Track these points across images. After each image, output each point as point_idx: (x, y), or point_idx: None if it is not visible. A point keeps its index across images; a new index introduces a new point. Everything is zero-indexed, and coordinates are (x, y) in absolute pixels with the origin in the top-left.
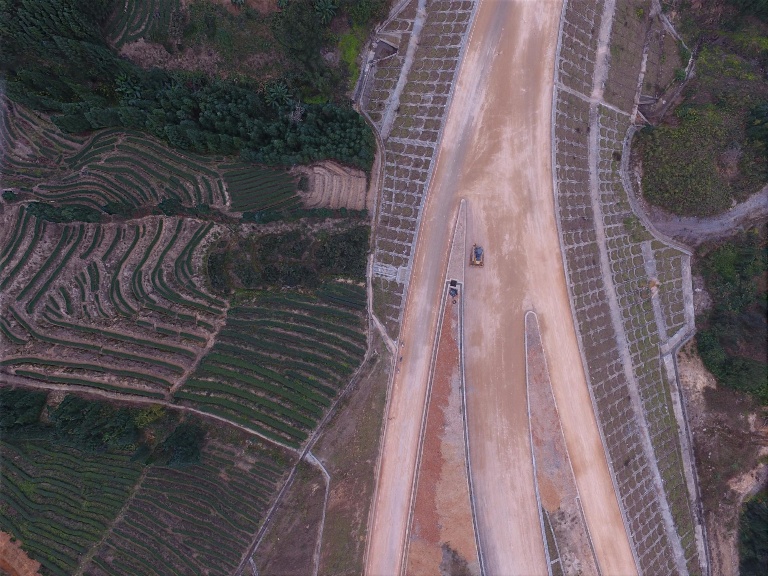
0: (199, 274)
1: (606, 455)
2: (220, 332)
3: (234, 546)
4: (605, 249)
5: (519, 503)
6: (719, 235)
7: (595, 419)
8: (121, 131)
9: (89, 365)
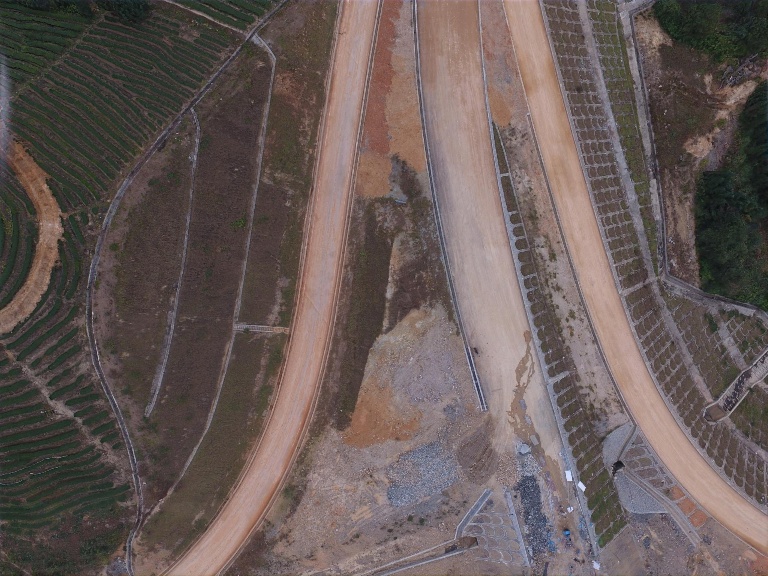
0: None
1: (557, 71)
2: None
3: (175, 96)
4: None
5: (469, 117)
6: None
7: (546, 36)
8: None
9: None
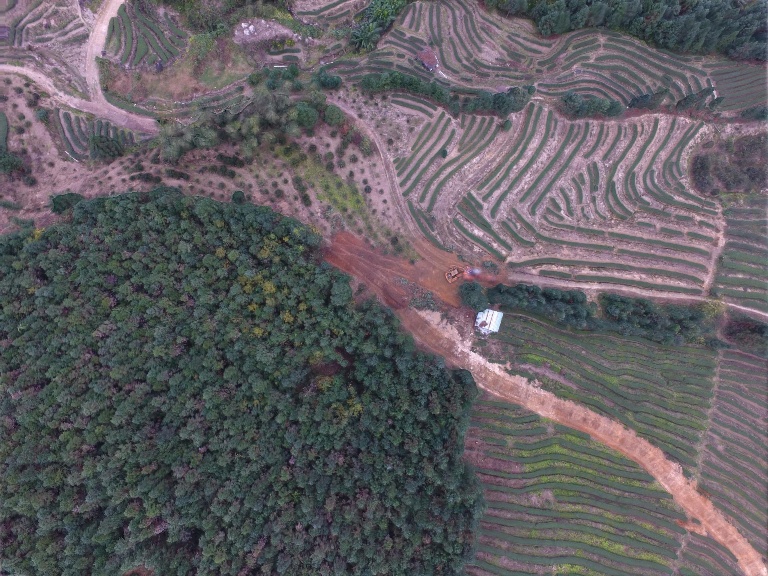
0: (686, 176)
1: None
2: (726, 231)
3: None
4: None
5: None
6: None
7: None
8: (596, 32)
9: (614, 264)
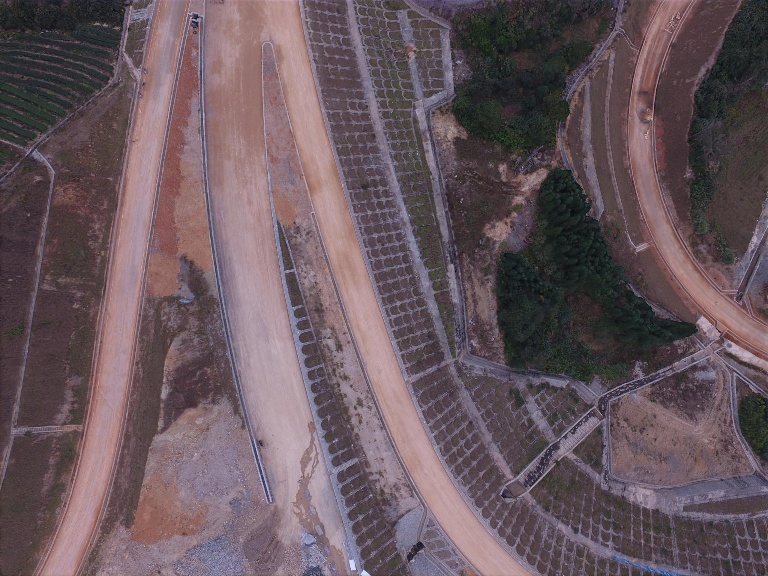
0: None
1: (338, 172)
2: None
3: None
4: (352, 4)
5: (255, 217)
6: (471, 7)
7: (329, 140)
8: None
9: None
